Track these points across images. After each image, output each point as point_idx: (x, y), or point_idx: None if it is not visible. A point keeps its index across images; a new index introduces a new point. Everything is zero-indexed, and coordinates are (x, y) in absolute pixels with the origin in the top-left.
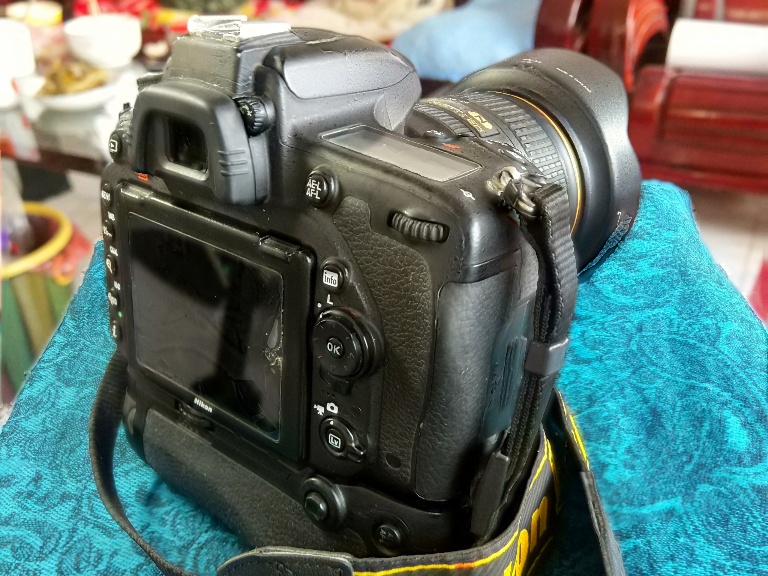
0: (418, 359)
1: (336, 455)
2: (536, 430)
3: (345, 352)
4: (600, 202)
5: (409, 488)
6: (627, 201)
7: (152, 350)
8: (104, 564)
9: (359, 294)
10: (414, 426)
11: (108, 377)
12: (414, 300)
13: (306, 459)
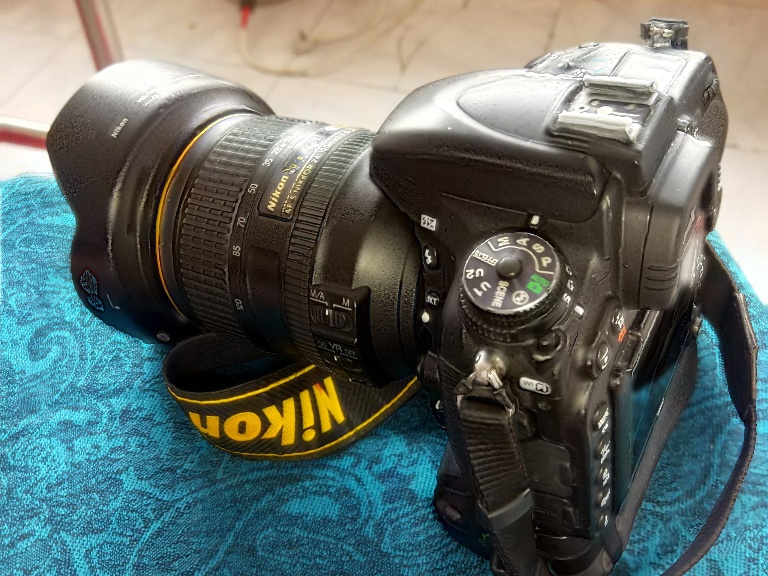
0: None
1: None
2: None
3: None
4: None
5: None
6: None
7: None
8: None
9: None
10: None
11: None
12: None
13: None
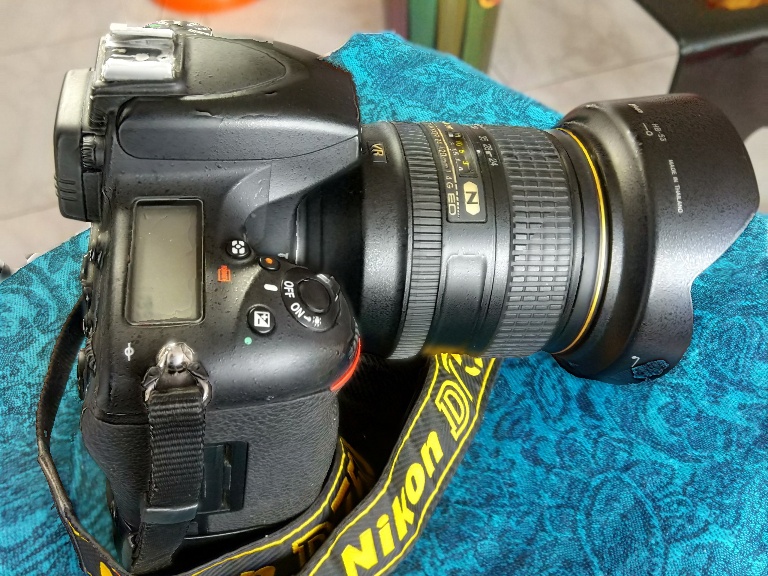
0: None
1: None
2: (163, 544)
3: None
4: (616, 335)
5: None
6: (657, 351)
7: None
8: None
9: None
10: None
11: None
12: None
13: None
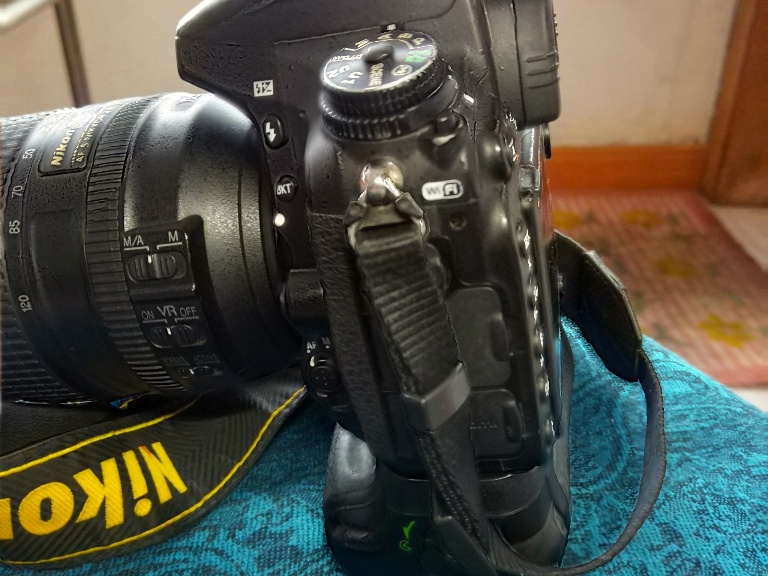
0: None
1: None
2: None
3: None
4: None
5: None
6: None
7: None
8: (670, 548)
9: None
10: None
11: (538, 572)
12: None
13: None
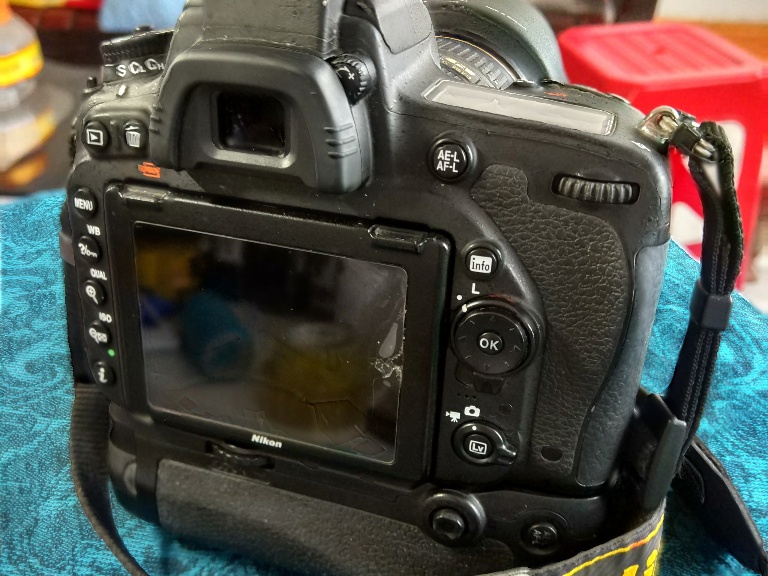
0: (599, 338)
1: (479, 463)
2: None
3: (504, 346)
4: None
5: (569, 479)
6: None
7: (171, 389)
8: None
9: (515, 277)
10: (583, 411)
11: (76, 433)
12: (594, 273)
13: (431, 475)
